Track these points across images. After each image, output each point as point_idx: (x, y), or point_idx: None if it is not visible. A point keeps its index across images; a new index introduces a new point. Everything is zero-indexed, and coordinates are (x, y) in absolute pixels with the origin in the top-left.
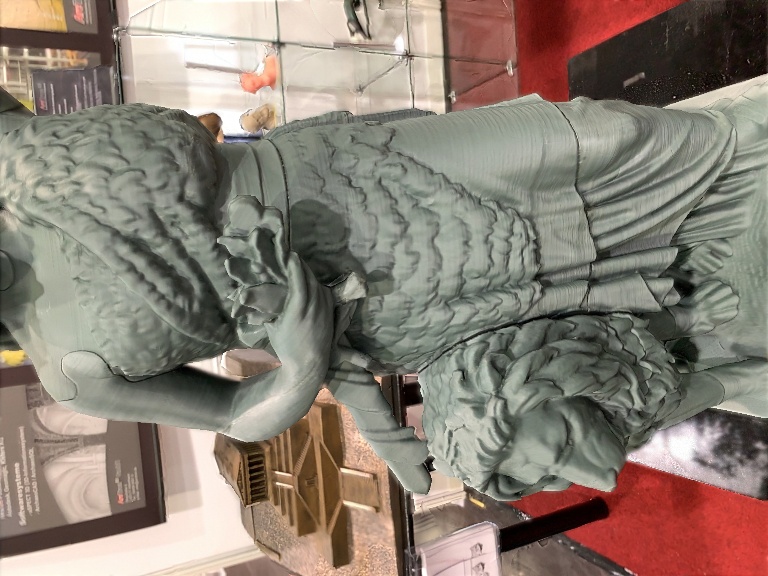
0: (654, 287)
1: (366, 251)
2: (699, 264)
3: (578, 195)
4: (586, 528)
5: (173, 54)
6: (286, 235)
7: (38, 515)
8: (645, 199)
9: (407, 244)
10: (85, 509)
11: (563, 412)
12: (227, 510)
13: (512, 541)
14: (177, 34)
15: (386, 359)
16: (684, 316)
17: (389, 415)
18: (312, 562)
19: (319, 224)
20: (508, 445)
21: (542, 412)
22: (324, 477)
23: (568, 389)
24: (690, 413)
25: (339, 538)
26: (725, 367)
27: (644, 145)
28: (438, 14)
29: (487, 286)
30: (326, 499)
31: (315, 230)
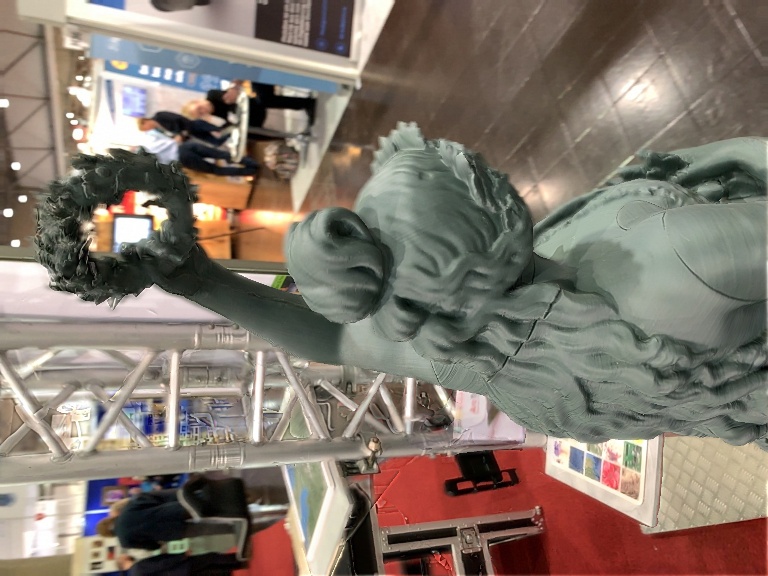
0: None
1: None
2: None
3: None
4: None
5: None
6: None
7: None
8: None
9: None
10: None
11: None
12: None
13: None
14: None
15: None
16: None
17: None
18: None
19: None
20: None
21: None
22: None
23: None
24: None
25: None
26: None
27: None
28: None
29: None
30: None
31: None
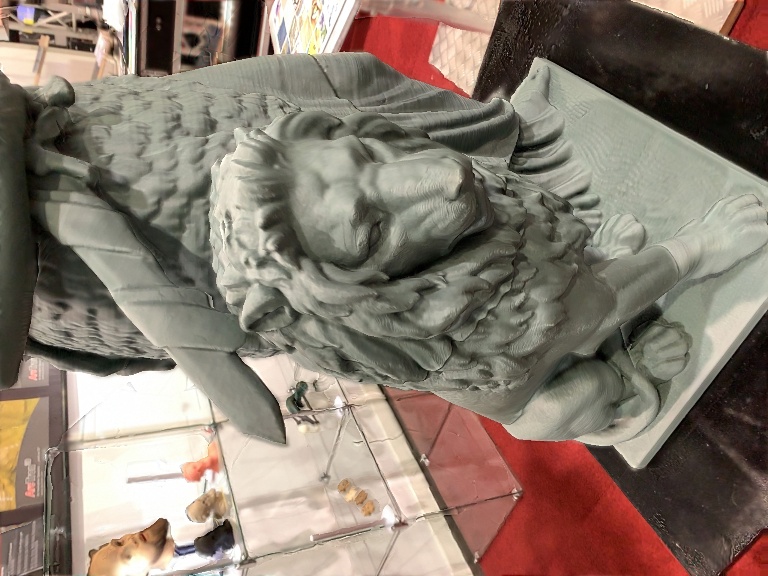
0: None
1: (86, 100)
2: None
3: None
4: None
5: (127, 502)
6: None
7: None
8: (427, 113)
9: (137, 97)
10: None
11: None
12: None
13: None
14: (110, 439)
15: (138, 207)
16: None
17: (154, 266)
18: None
19: None
20: (281, 163)
21: None
22: None
23: (346, 118)
24: (644, 280)
25: None
26: None
27: (399, 82)
28: (385, 403)
29: None
30: None
31: None
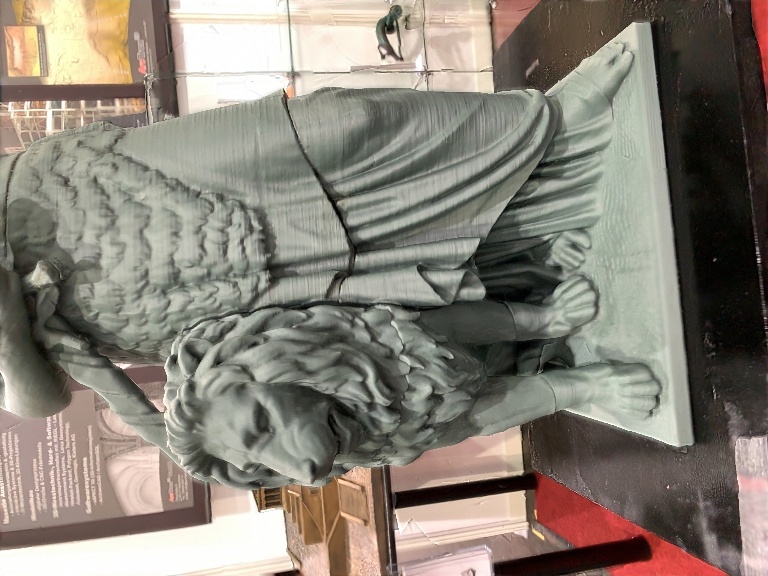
0: (437, 279)
1: (72, 243)
2: (561, 258)
3: (318, 185)
4: (632, 570)
5: None
6: (2, 230)
7: (101, 505)
8: (414, 186)
9: (113, 236)
10: (140, 504)
11: (258, 398)
12: (275, 518)
13: (525, 573)
14: (198, 74)
15: (123, 345)
16: (530, 314)
17: (136, 399)
18: (323, 573)
19: (30, 220)
20: (198, 428)
21: (234, 397)
22: (324, 487)
23: (258, 375)
24: (515, 419)
25: (337, 550)
26: (565, 370)
27: (400, 130)
28: (487, 27)
29: (208, 275)
30: (326, 509)
31: (26, 225)
